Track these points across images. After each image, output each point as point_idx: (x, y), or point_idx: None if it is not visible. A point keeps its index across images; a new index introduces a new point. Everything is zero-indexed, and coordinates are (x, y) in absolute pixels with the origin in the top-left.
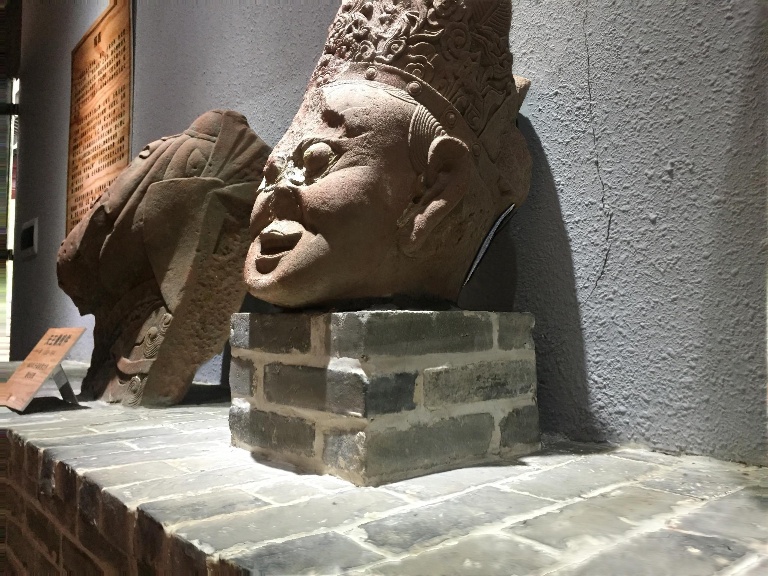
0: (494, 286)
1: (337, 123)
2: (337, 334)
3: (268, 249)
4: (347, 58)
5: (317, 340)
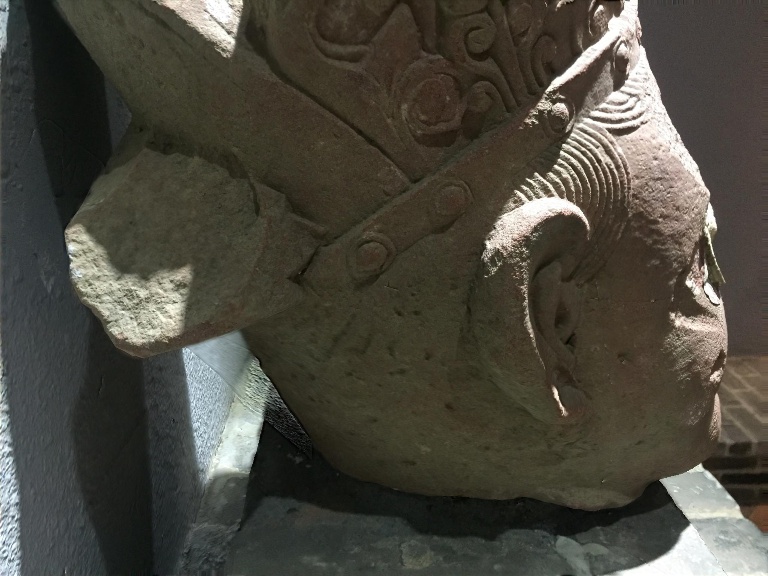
0: (127, 396)
1: None
2: None
3: None
4: None
5: None
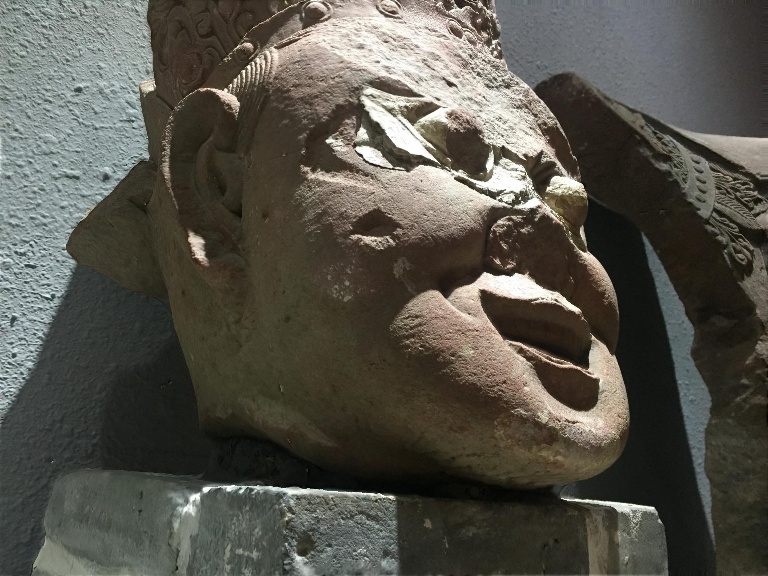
0: None
1: (568, 166)
2: (631, 551)
3: (548, 345)
4: (485, 40)
5: (596, 567)
